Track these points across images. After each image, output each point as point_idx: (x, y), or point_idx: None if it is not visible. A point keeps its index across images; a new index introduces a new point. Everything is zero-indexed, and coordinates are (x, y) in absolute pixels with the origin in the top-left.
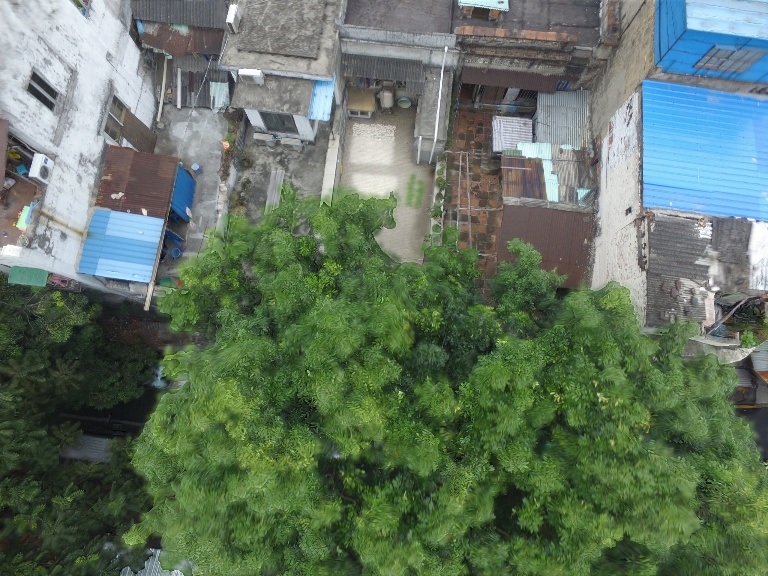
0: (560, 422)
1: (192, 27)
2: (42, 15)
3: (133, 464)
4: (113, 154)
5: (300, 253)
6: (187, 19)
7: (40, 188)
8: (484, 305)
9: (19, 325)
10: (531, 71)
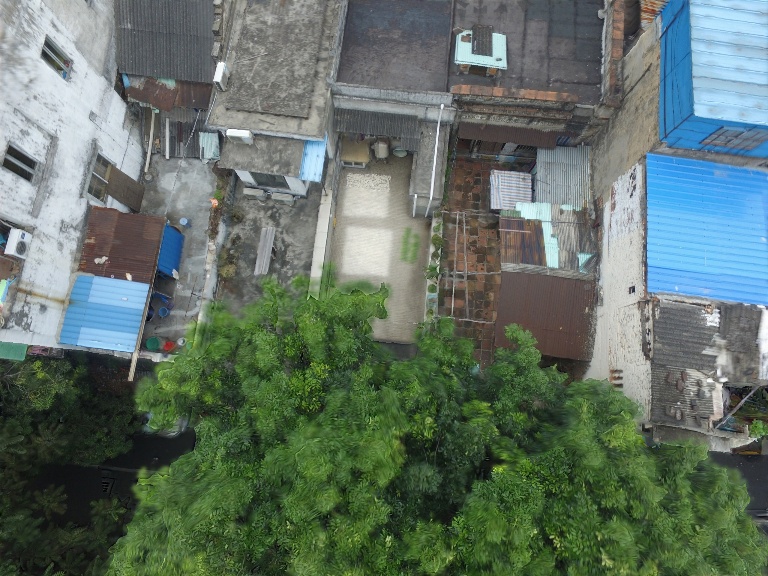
0: (560, 569)
1: (179, 81)
2: (18, 87)
3: None
4: (97, 216)
5: (285, 353)
6: (174, 73)
7: (17, 263)
8: (480, 401)
9: None
10: (530, 127)
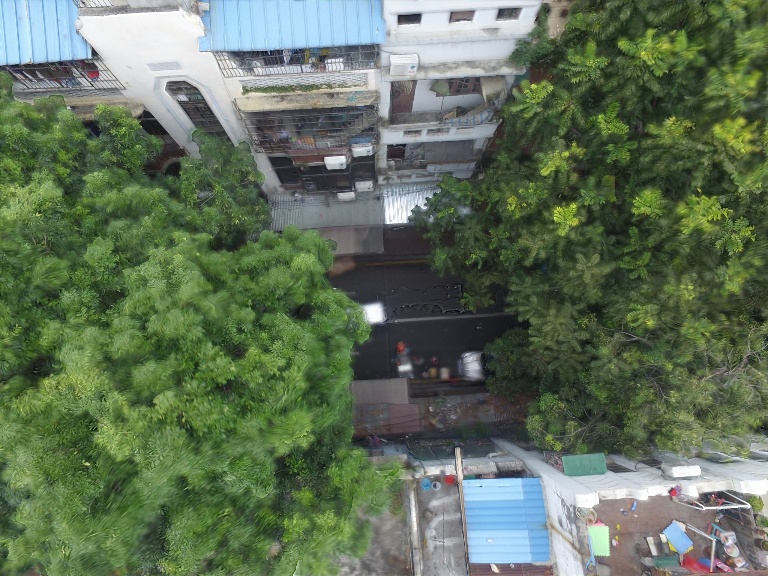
0: None
1: None
2: None
3: (361, 311)
4: None
5: None
6: None
7: None
8: None
9: (591, 404)
10: None
